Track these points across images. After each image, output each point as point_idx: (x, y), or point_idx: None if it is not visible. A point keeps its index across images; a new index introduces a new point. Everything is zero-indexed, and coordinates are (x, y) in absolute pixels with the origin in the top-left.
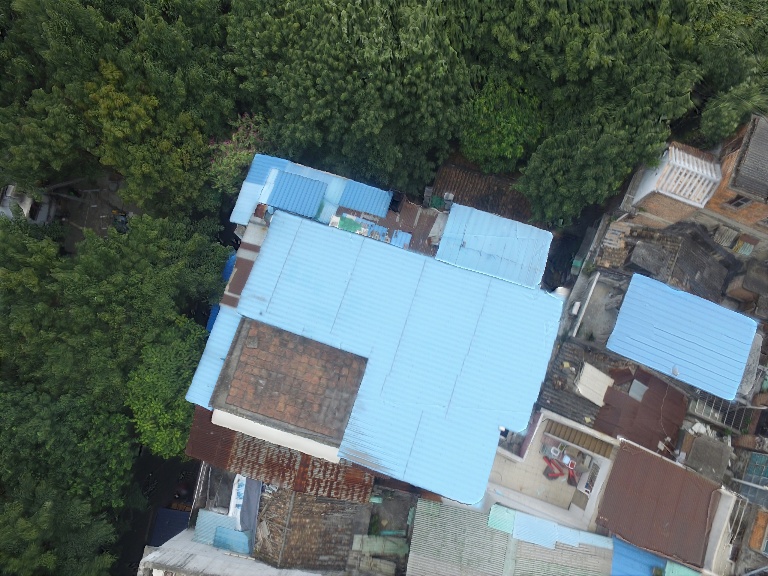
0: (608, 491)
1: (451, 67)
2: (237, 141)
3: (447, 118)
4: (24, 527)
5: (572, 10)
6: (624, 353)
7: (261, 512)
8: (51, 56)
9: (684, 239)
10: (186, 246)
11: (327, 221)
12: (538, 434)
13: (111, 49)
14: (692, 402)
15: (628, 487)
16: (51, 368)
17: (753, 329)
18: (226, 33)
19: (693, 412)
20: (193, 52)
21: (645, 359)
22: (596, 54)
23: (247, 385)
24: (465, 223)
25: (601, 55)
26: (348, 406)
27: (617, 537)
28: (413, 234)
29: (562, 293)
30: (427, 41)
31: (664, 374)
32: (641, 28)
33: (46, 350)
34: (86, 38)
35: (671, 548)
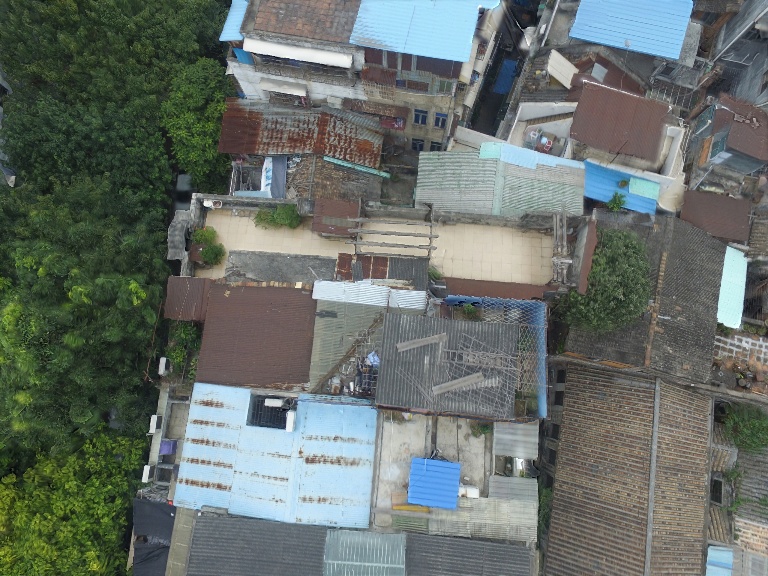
0: (576, 117)
1: None
2: None
3: None
4: (90, 187)
5: None
6: (584, 37)
7: (288, 182)
8: None
9: None
10: None
11: None
12: (519, 133)
13: None
14: (647, 92)
15: (592, 112)
16: (96, 89)
17: (690, 6)
18: None
19: (649, 98)
20: None
21: (602, 39)
22: None
23: (270, 15)
24: None
25: None
26: (354, 20)
27: (587, 161)
28: None
29: (531, 30)
30: None
31: (618, 49)
32: None
33: (89, 79)
34: None
35: (630, 149)
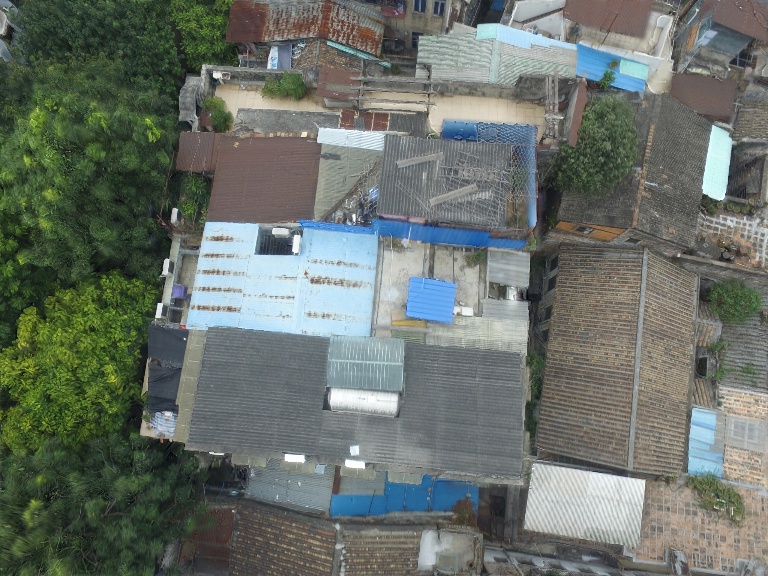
0: None
1: None
2: None
3: None
4: (104, 63)
5: None
6: None
7: (293, 67)
8: None
9: None
10: None
11: None
12: None
13: None
14: None
15: None
16: None
17: None
18: None
19: None
20: None
21: None
22: None
23: None
24: None
25: None
26: None
27: (580, 43)
28: None
29: None
30: None
31: None
32: None
33: None
34: None
35: (620, 27)
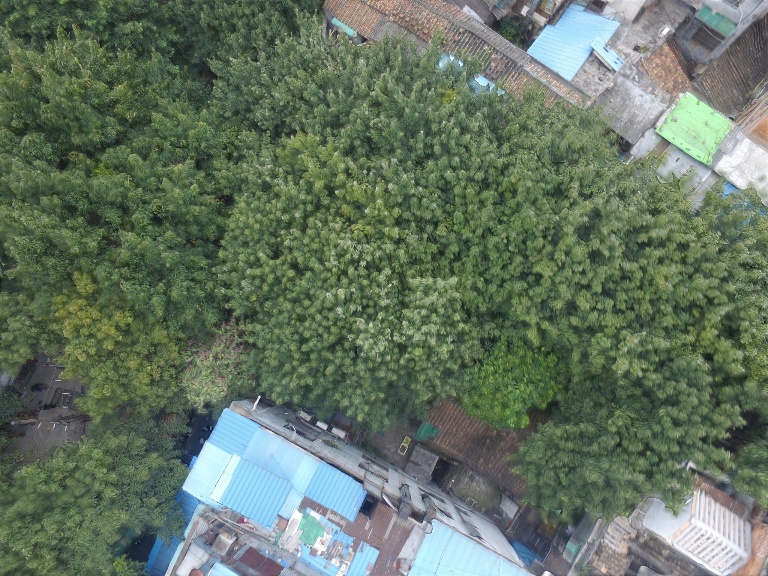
0: None
1: (459, 337)
2: (215, 359)
3: (446, 390)
4: None
5: (607, 289)
6: None
7: None
8: None
9: (697, 571)
10: (140, 473)
11: (288, 516)
12: None
13: (87, 264)
14: None
15: None
16: None
17: None
18: (224, 229)
19: None
20: (182, 256)
21: None
22: (625, 365)
23: None
24: (442, 550)
25: (631, 358)
26: None
27: None
28: (381, 551)
29: None
30: (432, 329)
31: None
32: (683, 325)
33: None
34: (61, 252)
35: None
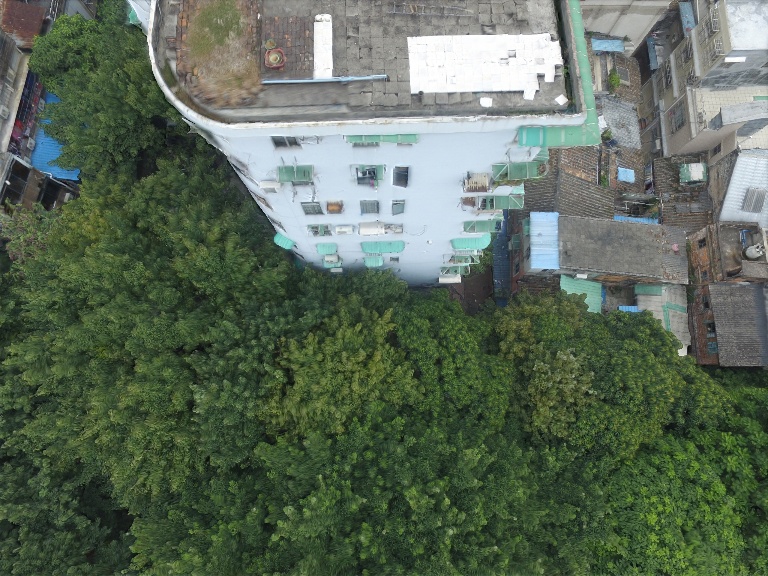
0: None
1: None
2: None
3: None
4: None
5: None
6: None
7: None
8: (128, 242)
9: None
10: (70, 149)
11: None
12: None
13: None
14: None
15: None
16: None
17: None
18: None
19: None
20: None
21: None
22: None
23: None
24: None
25: None
26: None
27: None
28: None
29: None
30: None
31: None
32: None
33: None
34: None
35: None
